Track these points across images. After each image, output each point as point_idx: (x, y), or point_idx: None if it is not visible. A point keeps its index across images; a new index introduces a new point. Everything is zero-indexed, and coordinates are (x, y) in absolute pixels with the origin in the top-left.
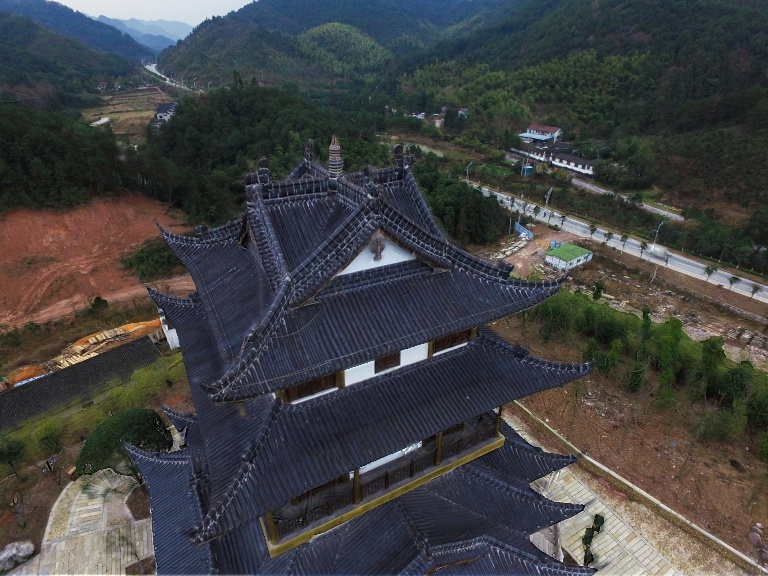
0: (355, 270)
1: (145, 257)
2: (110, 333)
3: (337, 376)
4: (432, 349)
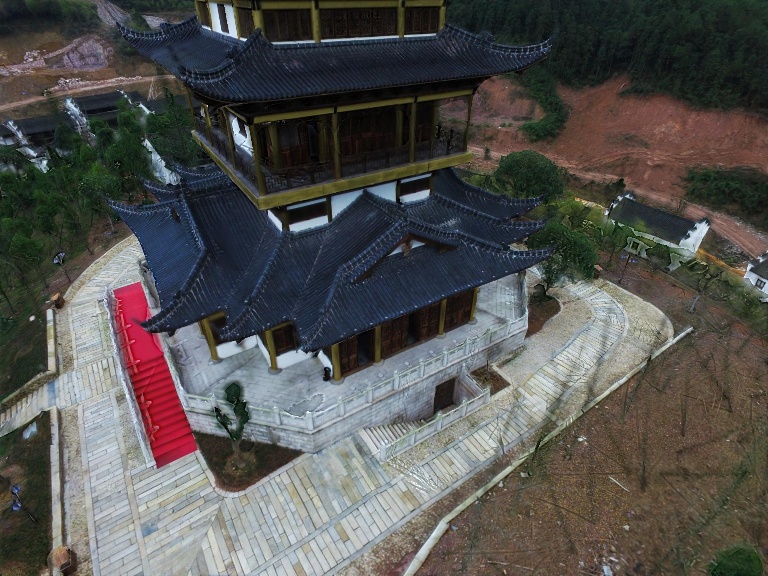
0: None
1: (713, 178)
2: (591, 204)
3: None
4: (239, 29)
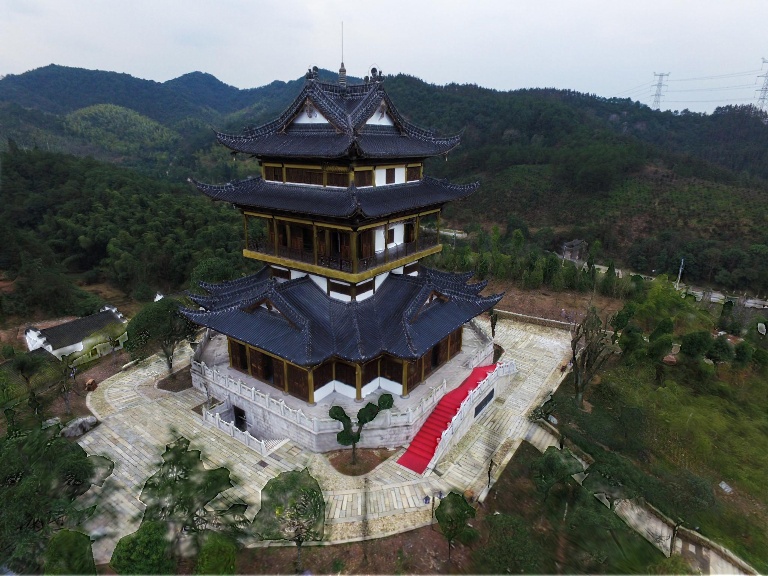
0: (371, 123)
1: None
2: None
3: (372, 178)
4: (406, 178)
